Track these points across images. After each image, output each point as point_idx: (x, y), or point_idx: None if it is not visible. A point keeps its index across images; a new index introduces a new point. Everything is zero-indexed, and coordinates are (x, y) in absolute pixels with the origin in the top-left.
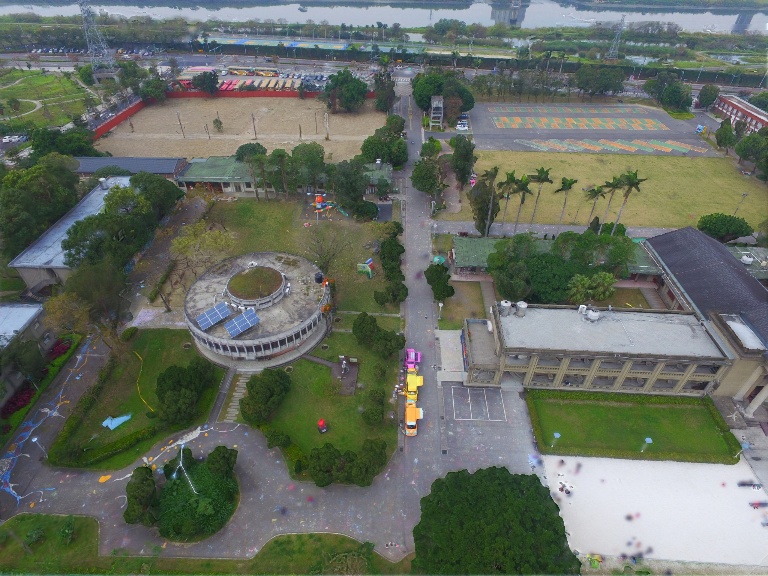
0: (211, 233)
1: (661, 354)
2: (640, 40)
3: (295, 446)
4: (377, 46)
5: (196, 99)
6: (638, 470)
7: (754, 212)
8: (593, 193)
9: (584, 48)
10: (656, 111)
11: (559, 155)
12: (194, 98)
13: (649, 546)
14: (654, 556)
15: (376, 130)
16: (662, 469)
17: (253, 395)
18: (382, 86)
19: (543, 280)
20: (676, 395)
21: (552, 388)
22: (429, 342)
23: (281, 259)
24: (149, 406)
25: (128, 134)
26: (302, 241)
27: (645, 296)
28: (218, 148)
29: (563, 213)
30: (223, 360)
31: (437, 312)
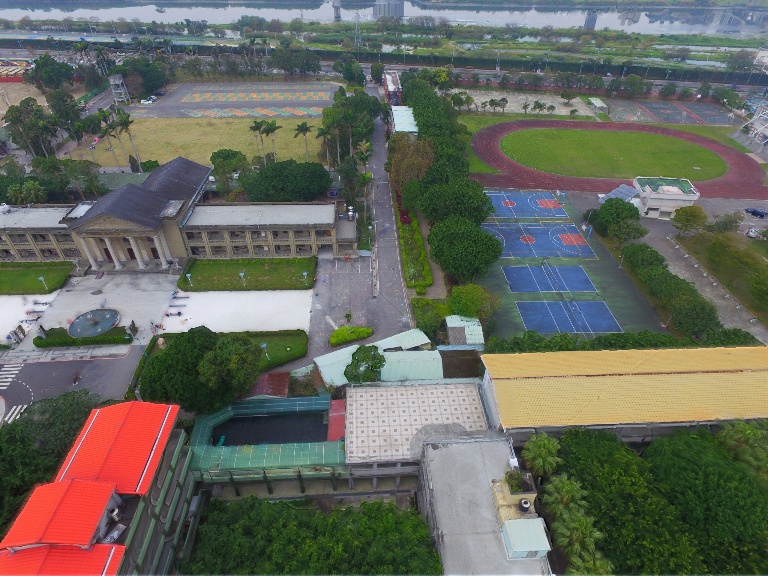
0: None
1: (20, 227)
2: (417, 32)
3: None
4: (137, 38)
5: None
6: None
7: (301, 153)
8: None
9: None
10: None
11: (203, 120)
12: None
13: None
14: None
15: (22, 101)
16: None
17: None
18: (80, 68)
19: None
20: None
21: None
22: None
23: None
24: None
25: None
26: None
27: None
28: None
29: (144, 159)
30: None
31: None
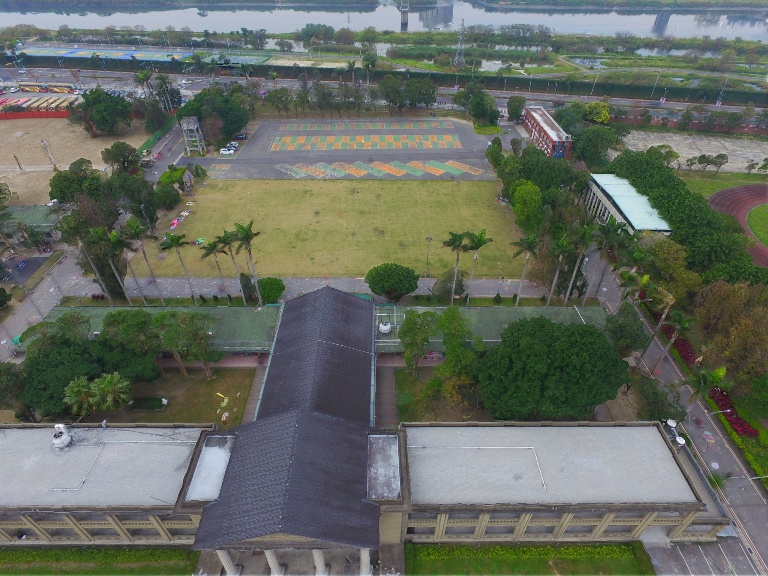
0: None
1: (94, 506)
2: (512, 44)
3: None
4: (198, 56)
5: None
6: None
7: None
8: (207, 250)
9: None
10: (464, 125)
11: (310, 183)
12: None
13: None
14: None
15: None
16: None
17: None
18: (141, 106)
19: (39, 385)
20: (166, 544)
21: (3, 543)
22: None
23: None
24: None
25: None
26: None
27: (254, 379)
28: None
29: None
30: None
31: None
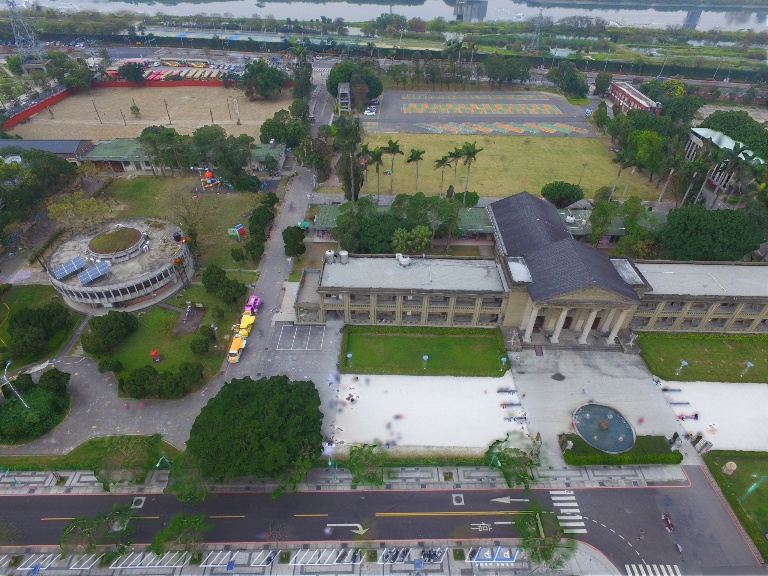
0: (85, 200)
1: (449, 289)
2: (570, 34)
3: (126, 371)
4: None
5: (122, 88)
6: (419, 383)
7: (606, 183)
8: (439, 163)
9: (514, 41)
10: (557, 98)
11: (451, 136)
12: (121, 87)
13: (405, 436)
14: (406, 443)
15: (275, 113)
16: (439, 382)
17: (93, 330)
18: (296, 74)
19: (371, 234)
20: (474, 327)
21: (369, 324)
22: (275, 291)
23: (150, 223)
24: (6, 345)
25: (47, 120)
26: (186, 211)
27: (480, 252)
28: (131, 132)
29: (435, 185)
30: (83, 308)
31: (291, 268)
